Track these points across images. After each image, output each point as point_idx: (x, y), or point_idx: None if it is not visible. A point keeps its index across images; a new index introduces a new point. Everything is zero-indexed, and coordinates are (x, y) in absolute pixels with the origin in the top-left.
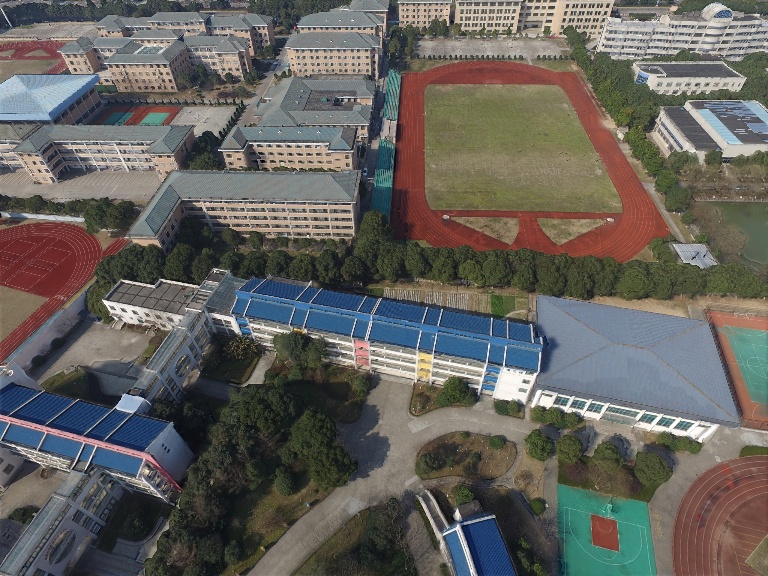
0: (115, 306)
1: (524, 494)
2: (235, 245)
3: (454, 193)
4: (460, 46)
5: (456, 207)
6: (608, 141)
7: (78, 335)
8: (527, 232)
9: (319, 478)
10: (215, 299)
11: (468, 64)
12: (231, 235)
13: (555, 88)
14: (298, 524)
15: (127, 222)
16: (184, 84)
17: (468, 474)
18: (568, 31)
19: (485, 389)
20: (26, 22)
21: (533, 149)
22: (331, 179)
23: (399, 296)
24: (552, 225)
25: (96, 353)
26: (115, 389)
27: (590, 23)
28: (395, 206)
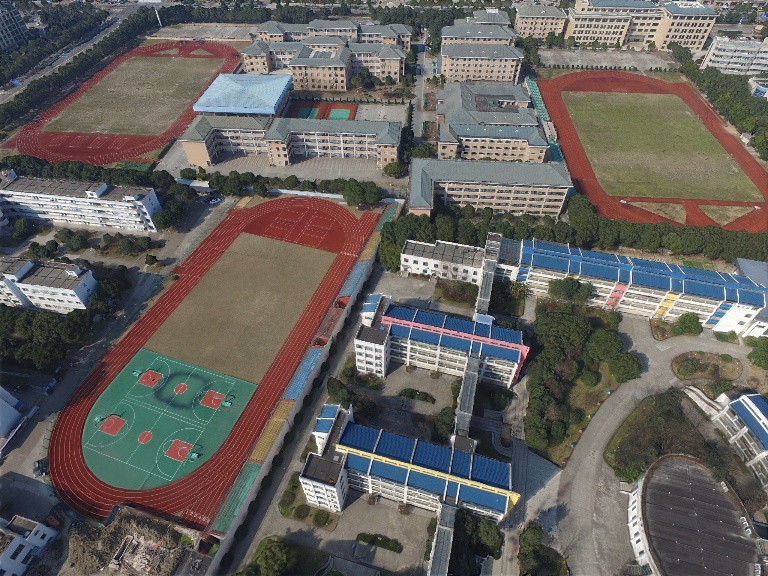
0: (410, 259)
1: (757, 390)
2: (467, 218)
3: (622, 183)
4: (576, 57)
5: (628, 194)
6: (735, 144)
7: (376, 280)
8: (694, 215)
9: (624, 371)
10: (503, 253)
11: (590, 73)
12: (472, 210)
13: (674, 97)
14: (605, 404)
15: (380, 198)
16: None
17: (714, 377)
18: (674, 46)
19: (708, 323)
20: (172, 22)
21: (674, 149)
22: (551, 168)
23: None
24: (712, 210)
25: (398, 293)
26: None
27: (690, 39)
28: (578, 192)
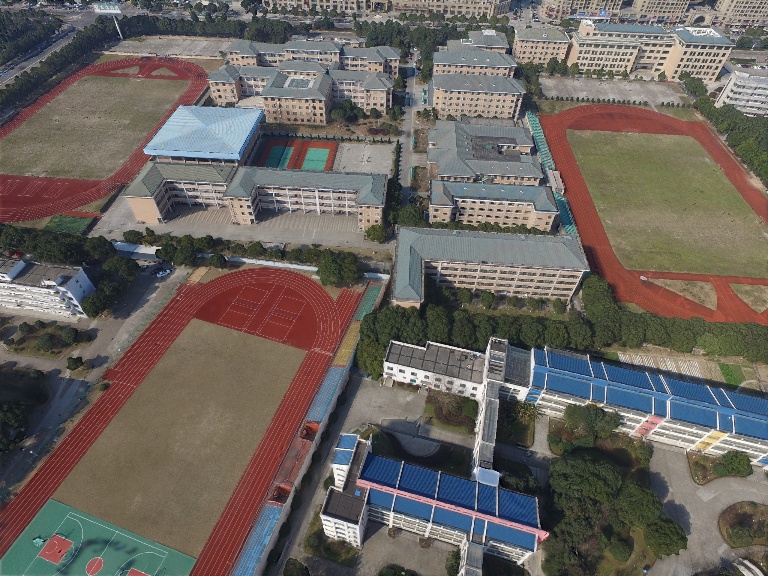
0: (395, 367)
1: None
2: None
3: (641, 253)
4: (580, 86)
5: (649, 268)
6: (762, 202)
7: (354, 391)
8: (725, 298)
9: (666, 550)
10: (510, 370)
11: (596, 108)
12: (469, 295)
13: (690, 140)
14: None
15: (360, 276)
16: (336, 119)
17: None
18: (687, 78)
19: None
20: (134, 34)
21: (696, 207)
22: (564, 247)
23: (635, 361)
24: (745, 291)
25: (380, 411)
26: (415, 449)
27: (703, 70)
28: (591, 264)
